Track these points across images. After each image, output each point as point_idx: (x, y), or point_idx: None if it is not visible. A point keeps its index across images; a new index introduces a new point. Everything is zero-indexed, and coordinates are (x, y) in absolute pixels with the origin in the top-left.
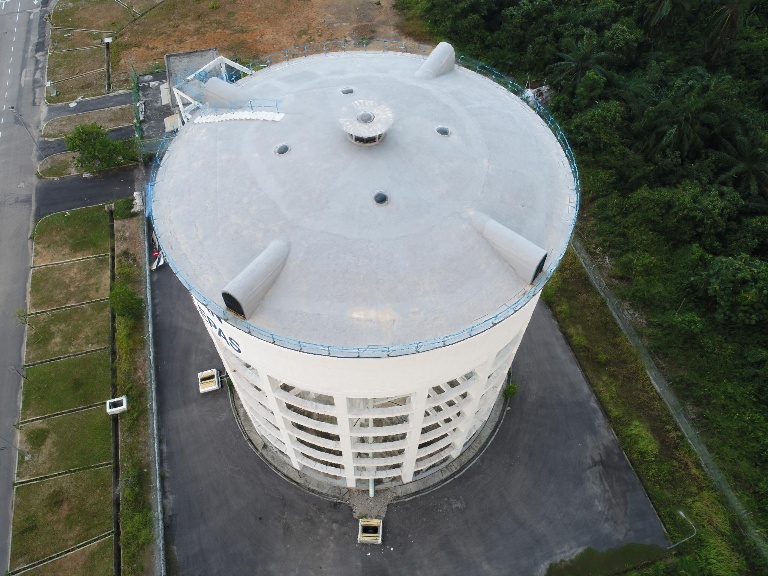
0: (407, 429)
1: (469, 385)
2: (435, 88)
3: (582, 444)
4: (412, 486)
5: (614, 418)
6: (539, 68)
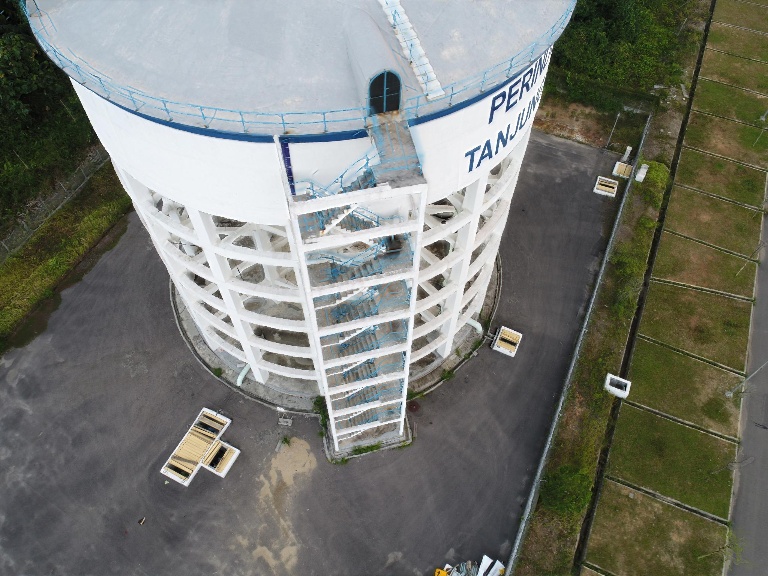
0: None
1: None
2: None
3: None
4: None
5: None
6: None
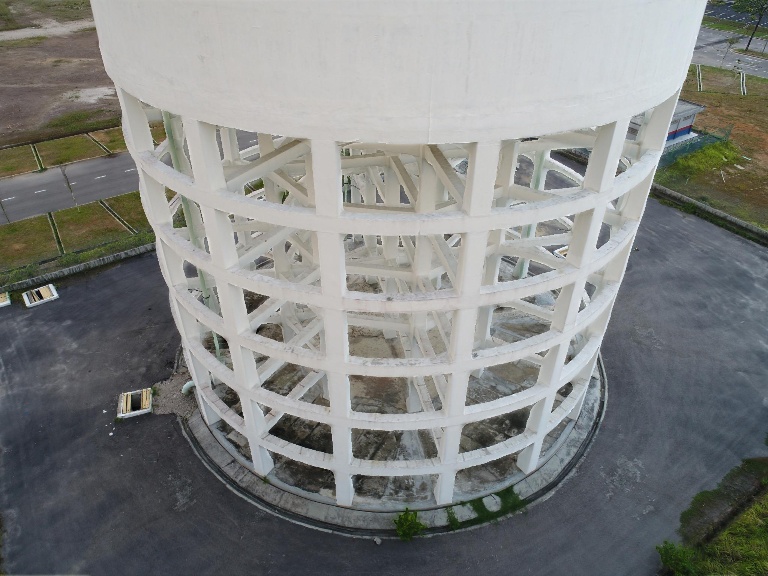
0: (149, 215)
1: (180, 179)
2: None
3: None
4: (203, 431)
5: None
6: None
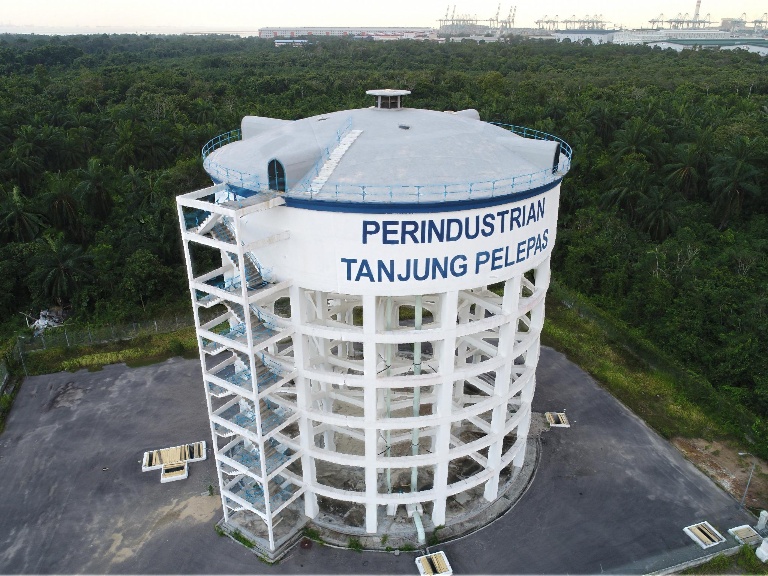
0: None
1: None
2: None
3: None
4: None
5: (425, 313)
6: (5, 314)
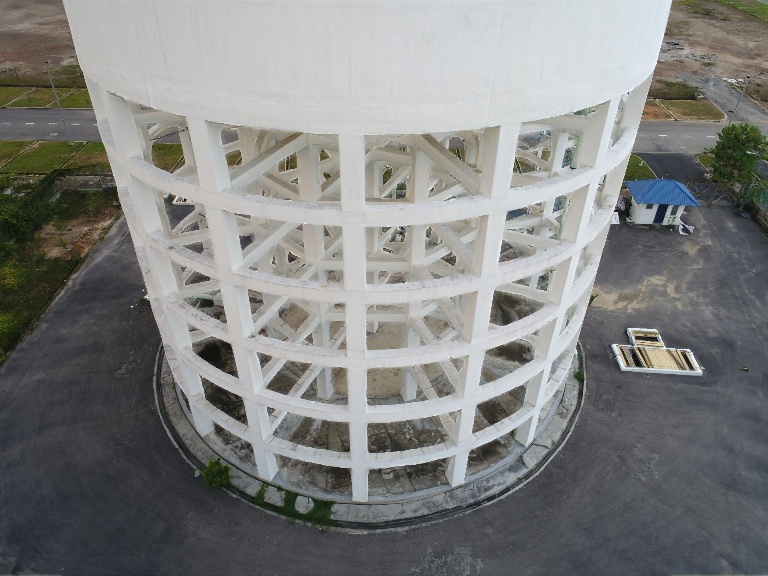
0: None
1: None
2: None
3: (59, 575)
4: None
5: None
6: None
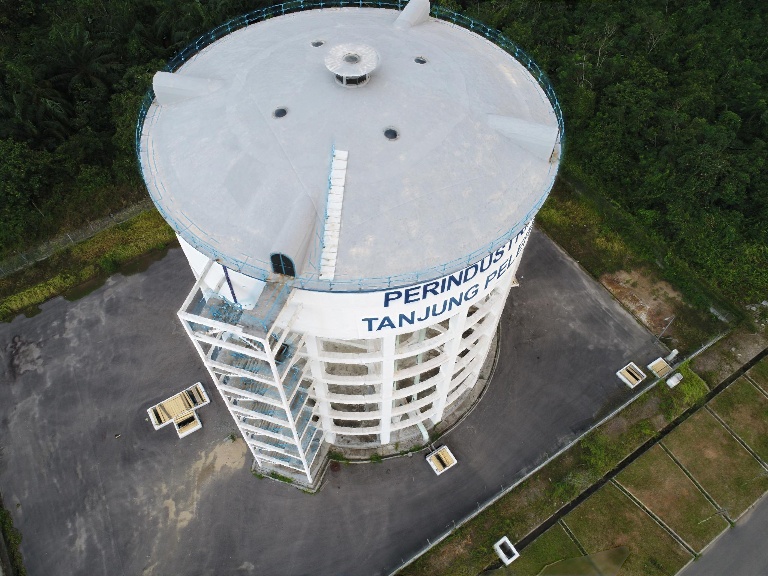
0: None
1: None
2: (241, 69)
3: None
4: None
5: None
6: None
